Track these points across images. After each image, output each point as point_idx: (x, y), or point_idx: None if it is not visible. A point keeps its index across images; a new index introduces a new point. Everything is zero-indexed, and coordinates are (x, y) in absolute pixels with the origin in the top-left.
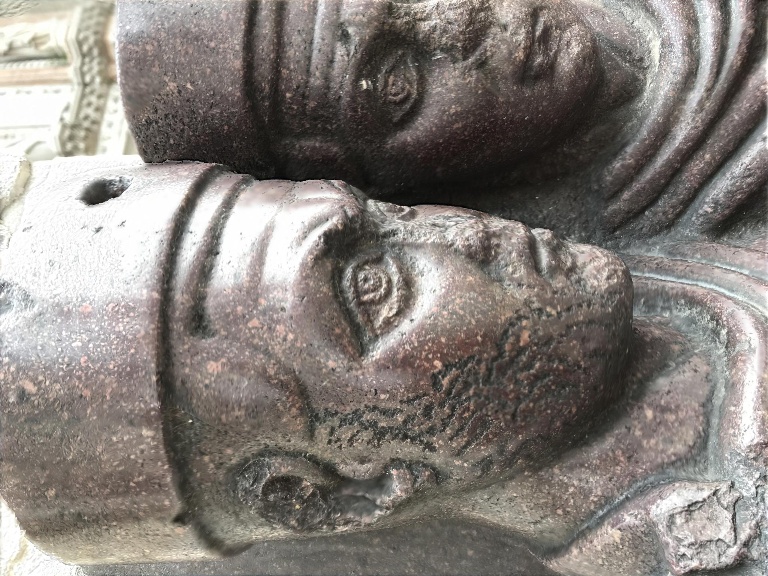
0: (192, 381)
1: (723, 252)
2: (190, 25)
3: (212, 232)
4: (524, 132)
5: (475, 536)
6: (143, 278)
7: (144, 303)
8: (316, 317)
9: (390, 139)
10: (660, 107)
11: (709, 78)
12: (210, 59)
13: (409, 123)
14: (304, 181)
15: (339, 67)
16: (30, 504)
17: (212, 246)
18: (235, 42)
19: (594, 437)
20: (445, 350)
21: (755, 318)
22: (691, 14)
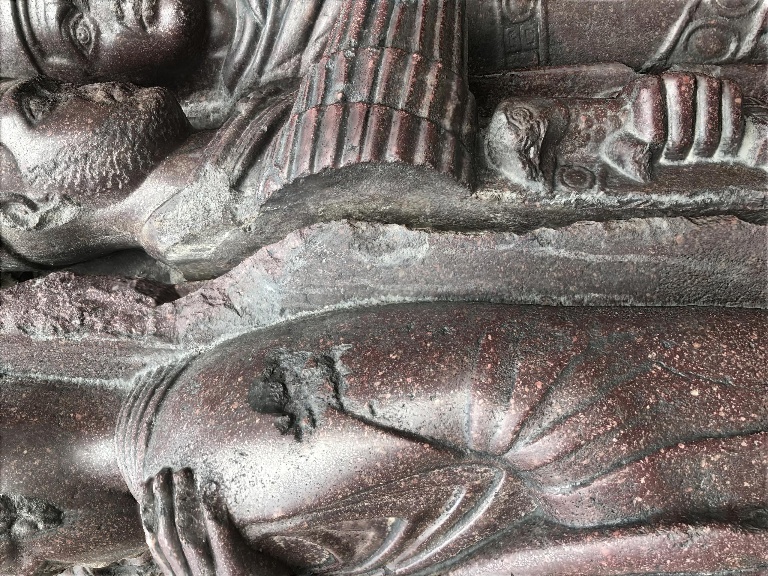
0: None
1: None
2: None
3: None
4: None
5: None
6: None
7: None
8: None
9: None
10: None
11: None
12: None
13: None
14: (76, 569)
15: None
16: None
17: None
18: None
19: None
20: None
21: None
22: None
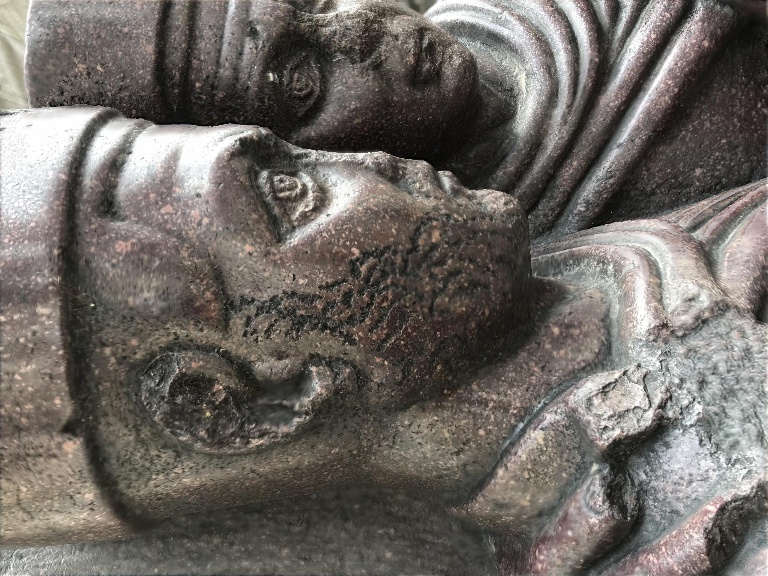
0: (97, 261)
1: (599, 228)
2: (104, 12)
3: (124, 138)
4: (417, 133)
5: (393, 535)
6: (49, 162)
7: (49, 182)
8: (233, 202)
9: (295, 134)
10: (531, 122)
11: (568, 97)
12: (122, 43)
13: (313, 119)
14: None
15: (248, 59)
16: None
17: (124, 147)
18: (148, 29)
19: (507, 354)
20: (362, 239)
21: (635, 248)
22: (547, 50)
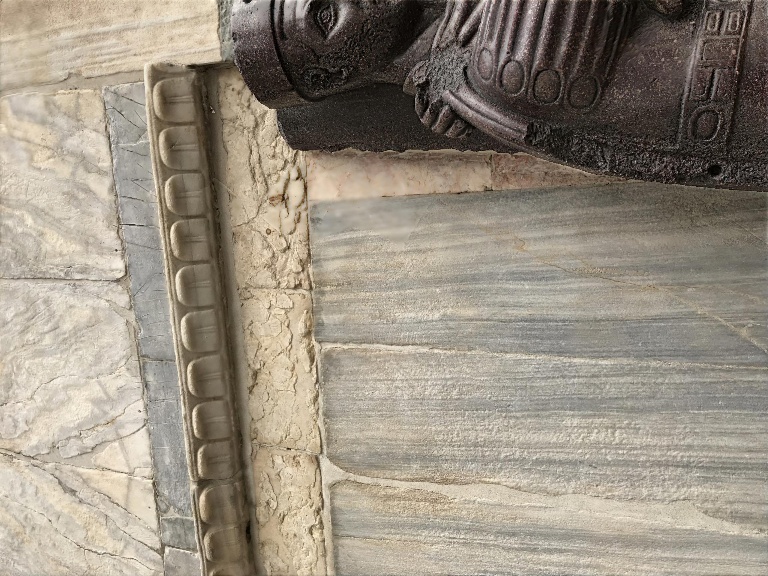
0: (285, 53)
1: None
2: None
3: (281, 8)
4: None
5: None
6: (266, 26)
7: (268, 34)
8: (311, 30)
9: None
10: None
11: None
12: None
13: None
14: None
15: None
16: (256, 90)
17: (282, 13)
18: None
19: (404, 51)
20: (347, 34)
21: (450, 4)
22: None
